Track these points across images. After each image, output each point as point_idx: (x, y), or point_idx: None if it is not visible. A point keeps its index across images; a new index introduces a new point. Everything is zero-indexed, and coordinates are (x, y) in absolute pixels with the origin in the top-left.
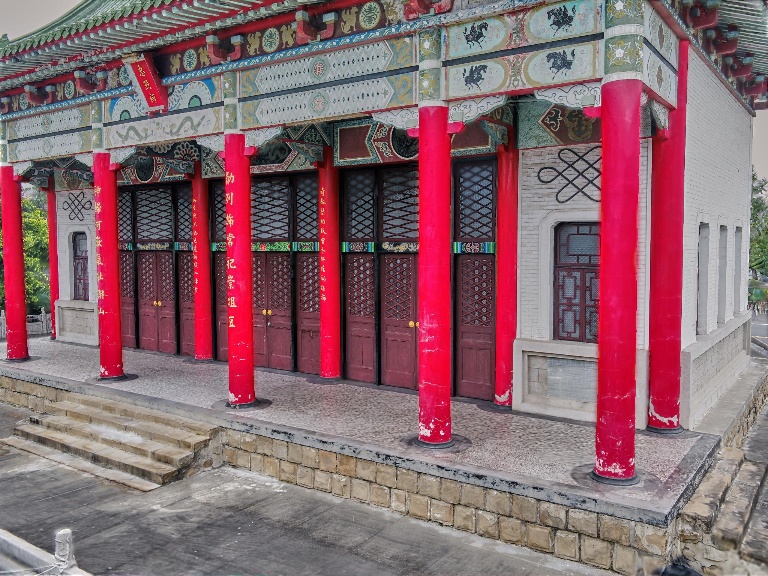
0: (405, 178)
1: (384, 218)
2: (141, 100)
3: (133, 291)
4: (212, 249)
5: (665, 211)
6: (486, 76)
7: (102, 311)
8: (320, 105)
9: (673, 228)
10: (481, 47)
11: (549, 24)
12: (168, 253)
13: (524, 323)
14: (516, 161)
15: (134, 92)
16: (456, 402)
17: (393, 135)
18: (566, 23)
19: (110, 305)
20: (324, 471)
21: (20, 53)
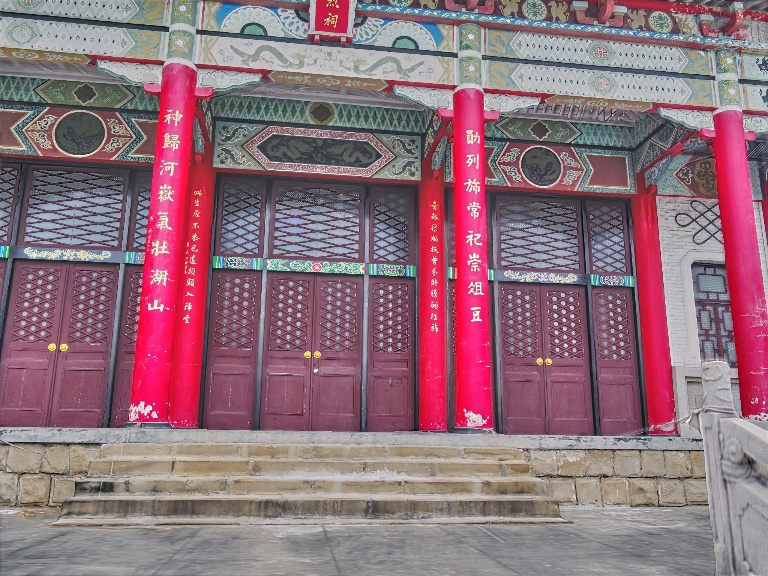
0: (527, 208)
1: (502, 246)
2: (310, 16)
3: None
4: (214, 265)
5: None
6: None
7: (160, 305)
8: (605, 86)
9: None
10: None
11: None
12: (101, 268)
13: (676, 352)
14: (654, 204)
15: (285, 5)
16: None
17: (523, 162)
18: None
19: (173, 297)
20: (701, 478)
21: None
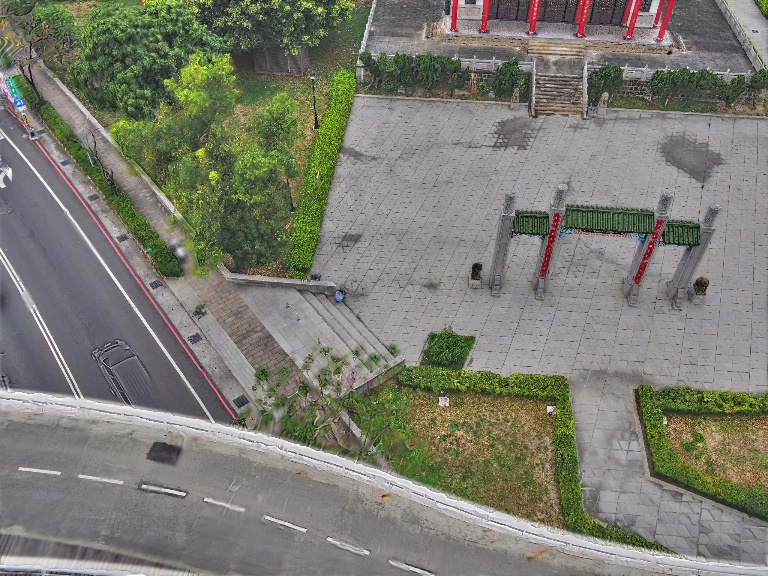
0: None
1: None
2: None
3: None
4: None
5: None
6: None
7: None
8: None
9: None
10: None
11: None
12: None
13: None
14: None
15: None
16: (614, 26)
17: None
18: None
19: None
20: None
21: None
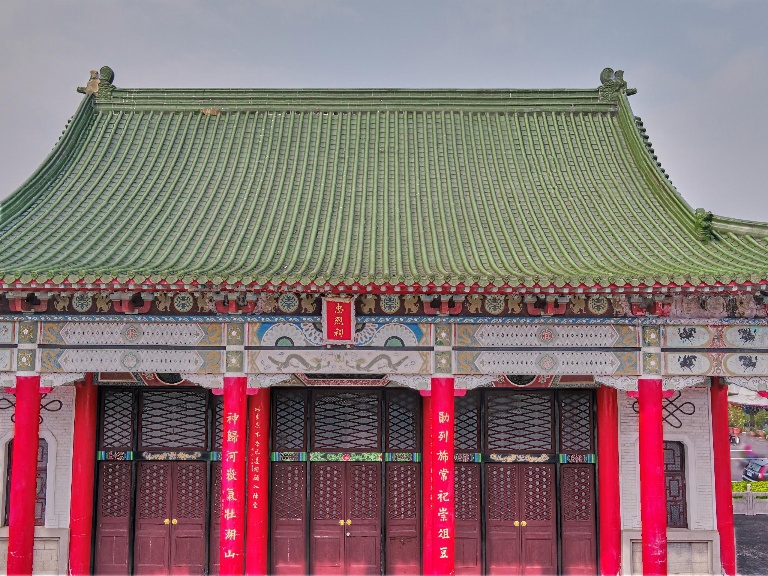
0: (510, 399)
1: (489, 432)
2: (323, 333)
3: (127, 509)
4: (272, 459)
5: (724, 436)
6: (696, 363)
7: (232, 554)
8: (548, 364)
9: (728, 447)
10: (692, 343)
11: (740, 337)
12: (195, 463)
13: (626, 517)
14: (615, 395)
15: None
16: None
17: None
18: (751, 339)
19: (240, 545)
20: None
21: (223, 283)
